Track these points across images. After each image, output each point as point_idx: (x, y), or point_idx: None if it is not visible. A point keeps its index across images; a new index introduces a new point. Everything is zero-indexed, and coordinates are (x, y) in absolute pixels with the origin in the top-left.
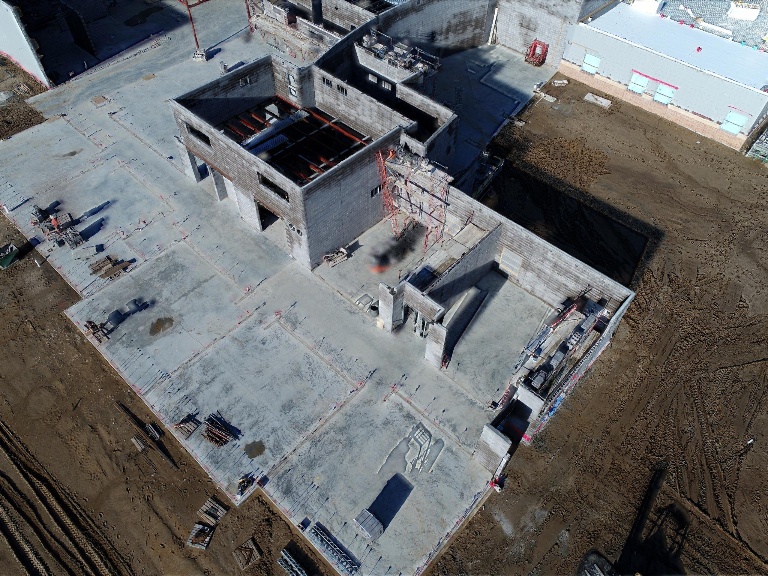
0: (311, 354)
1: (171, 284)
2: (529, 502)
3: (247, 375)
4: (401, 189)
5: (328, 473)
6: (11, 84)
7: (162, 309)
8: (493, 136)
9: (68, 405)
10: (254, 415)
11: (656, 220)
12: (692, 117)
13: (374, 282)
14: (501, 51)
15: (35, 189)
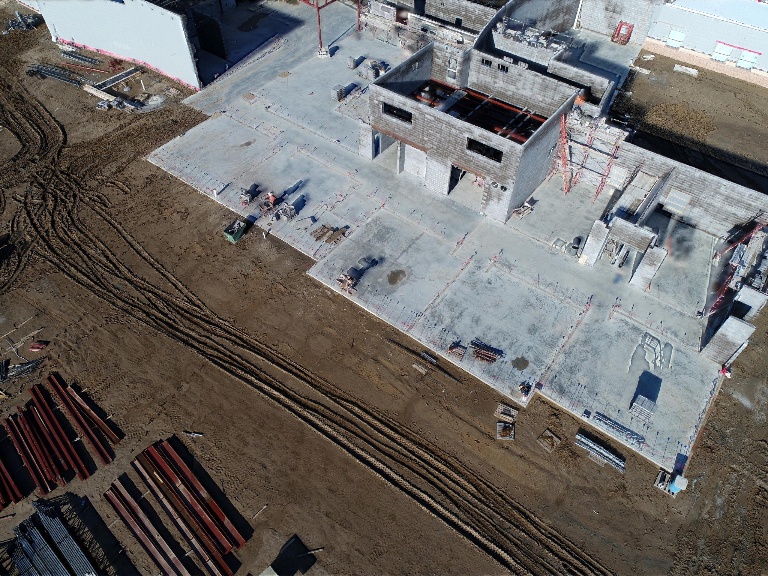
0: (534, 288)
1: (389, 243)
2: (756, 383)
3: (488, 308)
4: None
5: (589, 376)
6: (160, 88)
7: (391, 263)
8: (610, 105)
9: (345, 345)
10: (508, 338)
11: None
12: None
13: (561, 229)
14: (587, 34)
15: (230, 175)
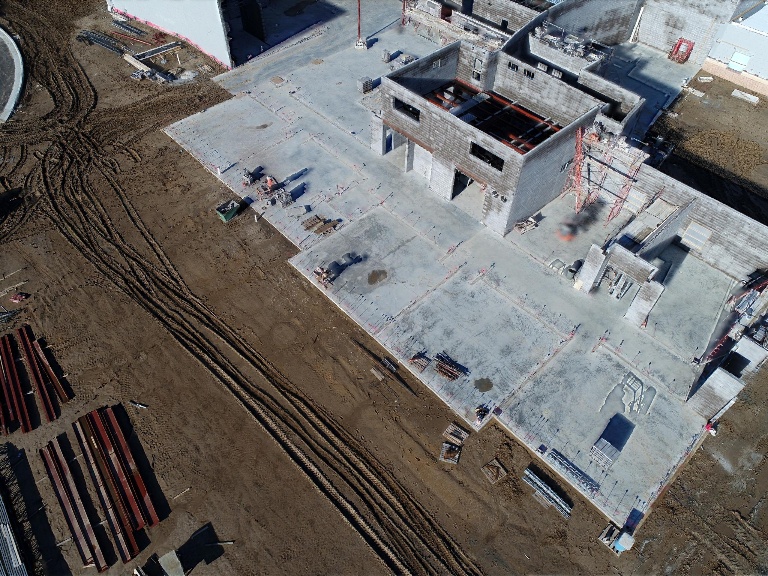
0: (518, 308)
1: (378, 242)
2: (744, 446)
3: (463, 322)
4: (582, 167)
5: (554, 409)
6: (195, 64)
7: (375, 263)
8: (650, 125)
9: (308, 339)
10: (477, 356)
11: None
12: None
13: (563, 249)
14: (643, 48)
15: (238, 155)
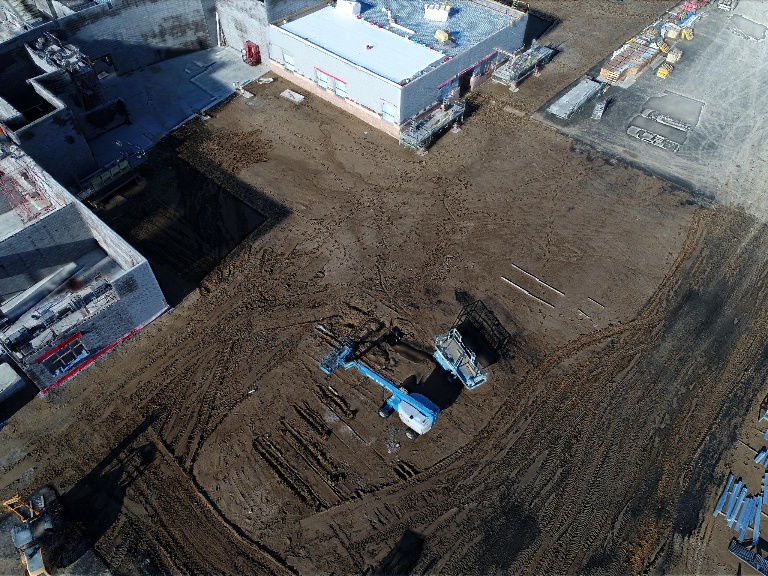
0: None
1: None
2: (14, 445)
3: None
4: None
5: None
6: None
7: None
8: (172, 129)
9: None
10: None
11: (285, 202)
12: (362, 110)
13: None
14: (227, 52)
15: None
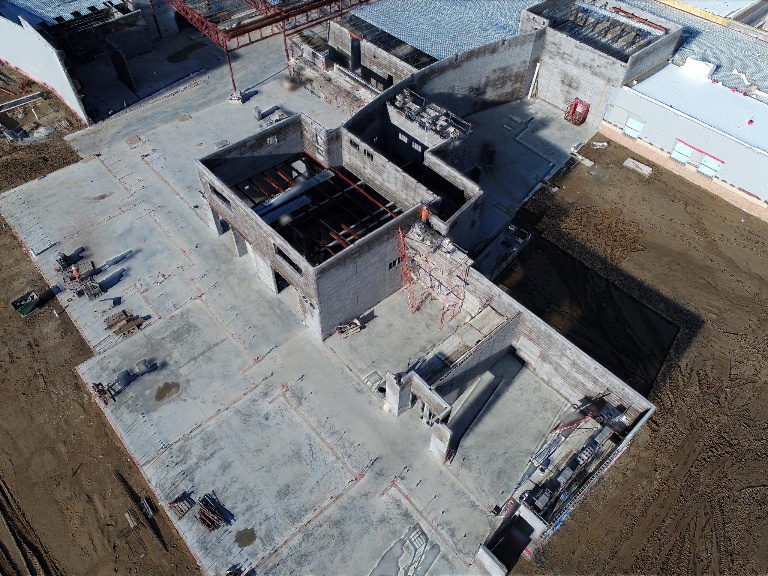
0: (313, 435)
1: (182, 345)
2: None
3: (246, 453)
4: None
5: (317, 572)
6: (53, 119)
7: (170, 372)
8: (523, 201)
9: (68, 470)
10: (249, 499)
11: (689, 307)
12: (738, 193)
13: (385, 358)
14: (540, 106)
15: (63, 233)
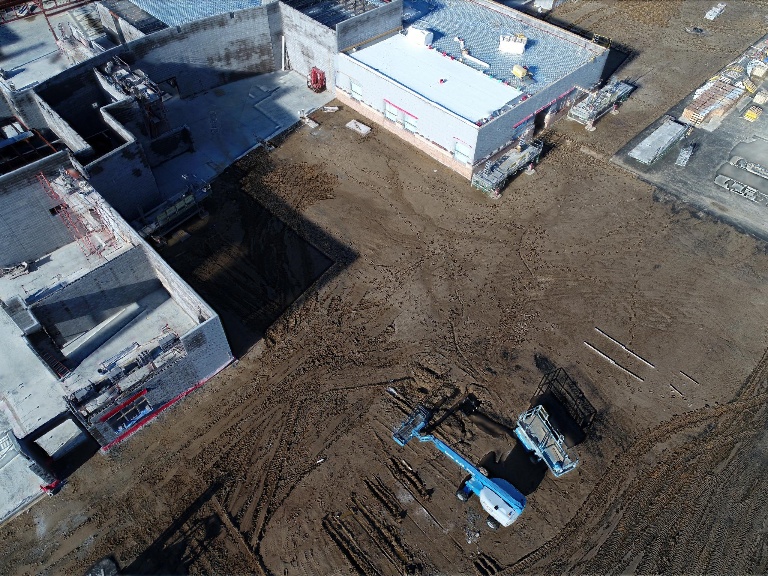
0: None
1: None
2: (74, 508)
3: None
4: None
5: None
6: None
7: None
8: (236, 159)
9: None
10: None
11: (352, 245)
12: (433, 146)
13: None
14: (291, 77)
15: None
